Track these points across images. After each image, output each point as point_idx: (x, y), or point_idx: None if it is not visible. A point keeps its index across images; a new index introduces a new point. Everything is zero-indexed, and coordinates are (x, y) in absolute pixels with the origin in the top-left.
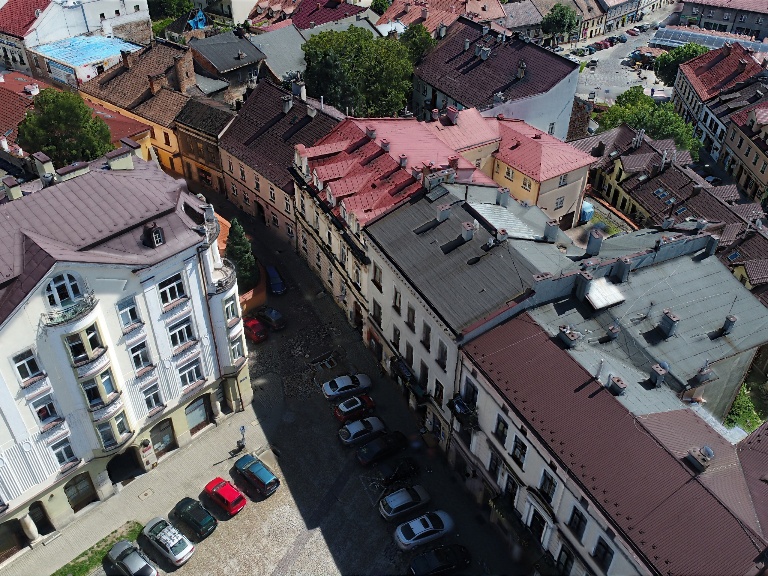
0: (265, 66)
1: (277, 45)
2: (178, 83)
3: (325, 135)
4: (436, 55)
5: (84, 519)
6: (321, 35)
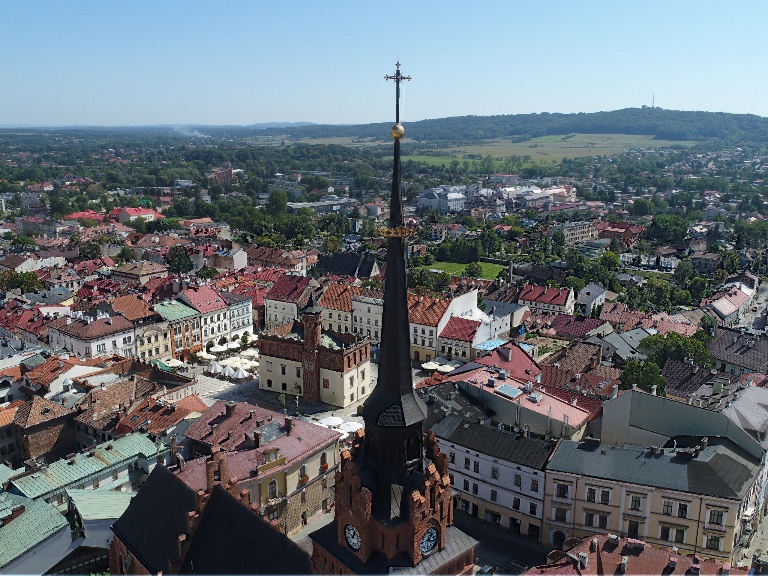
0: (616, 354)
1: (615, 343)
2: (598, 362)
3: (738, 381)
4: (715, 346)
5: (761, 529)
6: (656, 337)
